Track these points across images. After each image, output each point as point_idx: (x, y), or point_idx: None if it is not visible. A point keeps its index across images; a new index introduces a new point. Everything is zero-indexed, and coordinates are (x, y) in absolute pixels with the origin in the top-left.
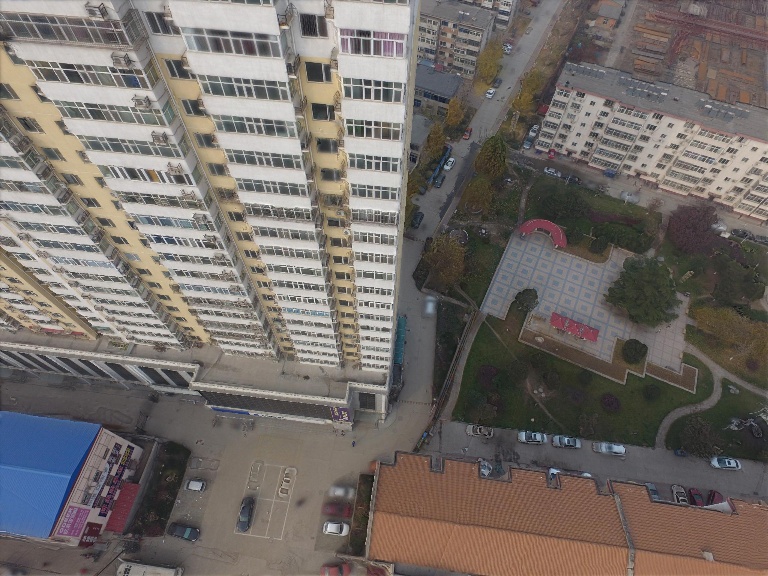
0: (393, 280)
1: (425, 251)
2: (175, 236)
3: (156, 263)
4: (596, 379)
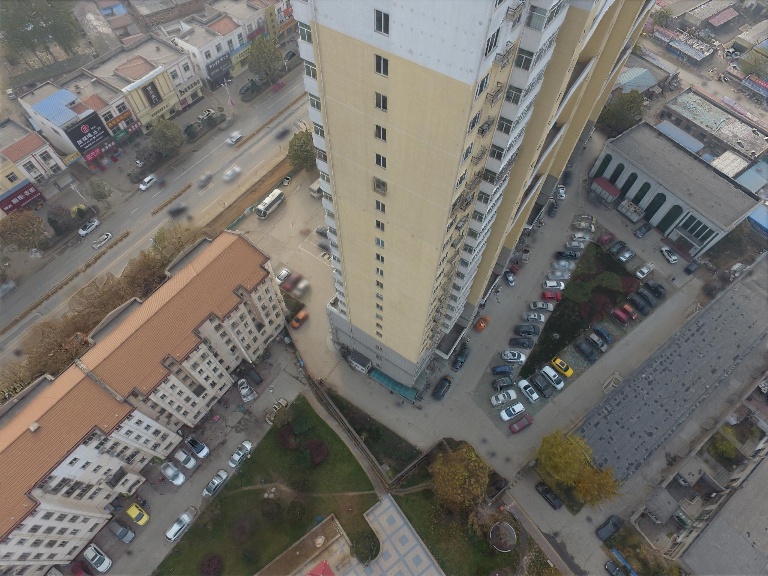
0: (327, 215)
1: (493, 474)
2: None
3: None
4: (243, 575)
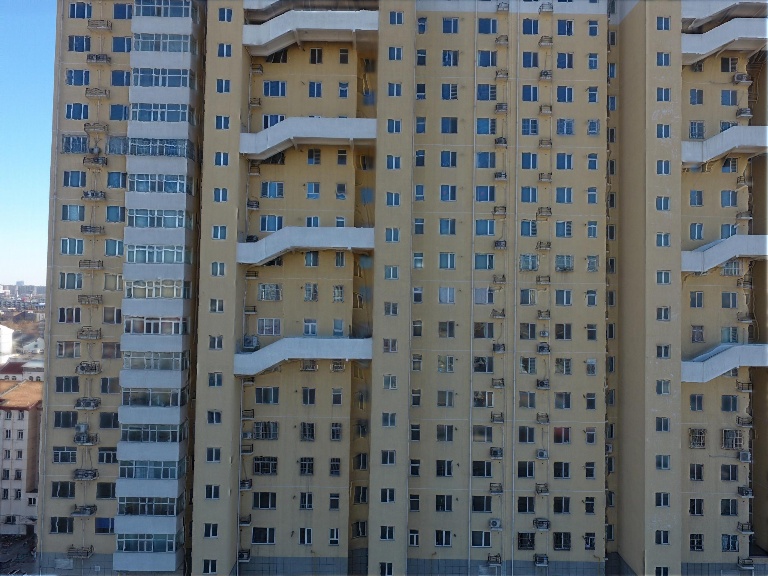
0: None
1: None
2: None
3: None
4: None
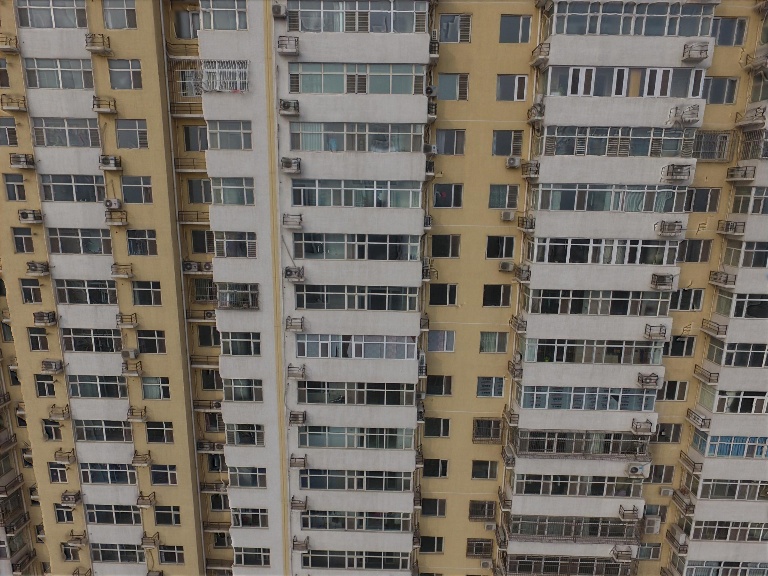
0: None
1: None
2: (595, 237)
3: (480, 353)
4: None
